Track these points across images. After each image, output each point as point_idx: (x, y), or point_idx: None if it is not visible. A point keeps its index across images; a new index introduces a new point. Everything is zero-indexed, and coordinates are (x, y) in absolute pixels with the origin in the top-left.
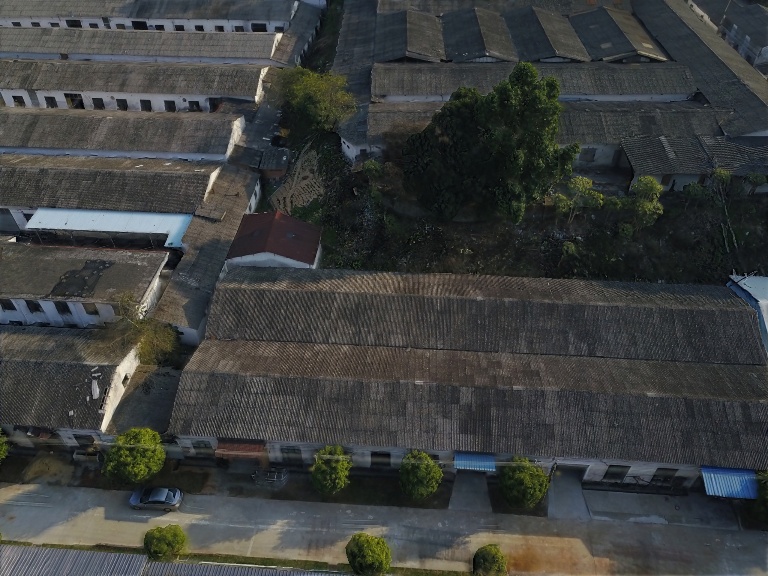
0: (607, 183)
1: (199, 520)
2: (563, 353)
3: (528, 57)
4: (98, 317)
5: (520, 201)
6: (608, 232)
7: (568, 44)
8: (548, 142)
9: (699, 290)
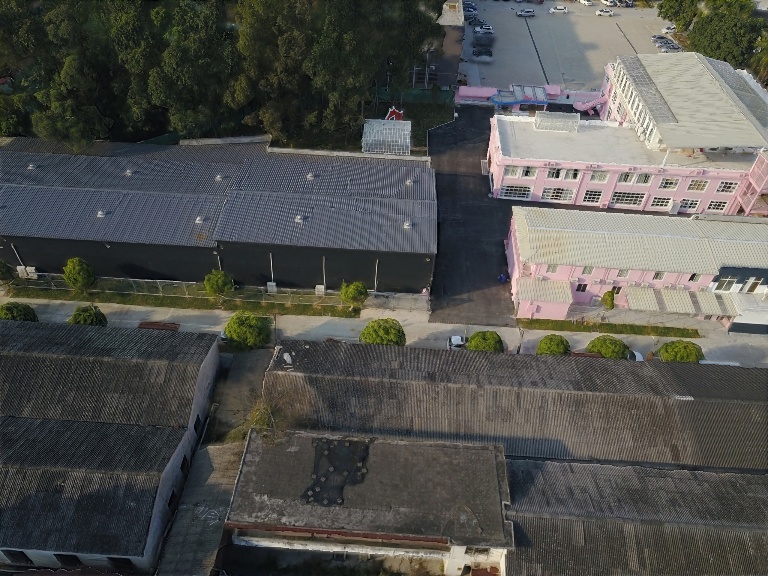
0: None
1: (208, 327)
2: None
3: None
4: None
5: None
6: None
7: None
8: None
9: None
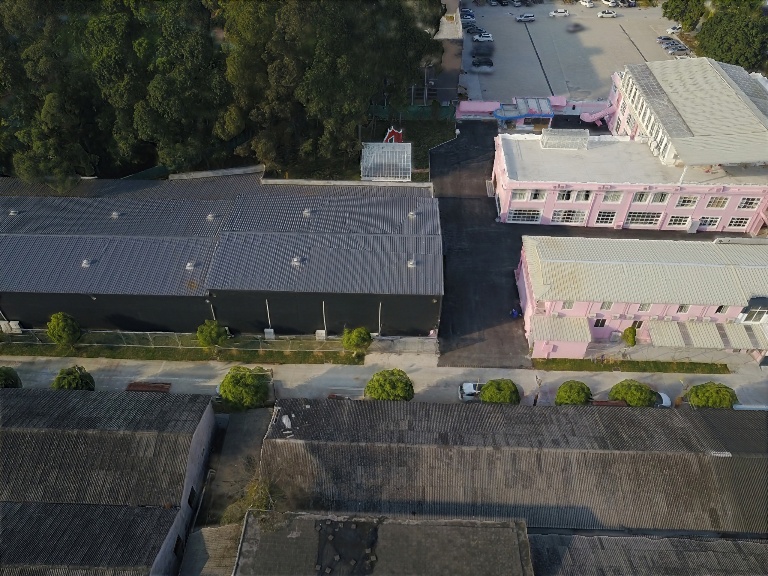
0: None
1: (203, 381)
2: None
3: None
4: None
5: None
6: None
7: None
8: None
9: None
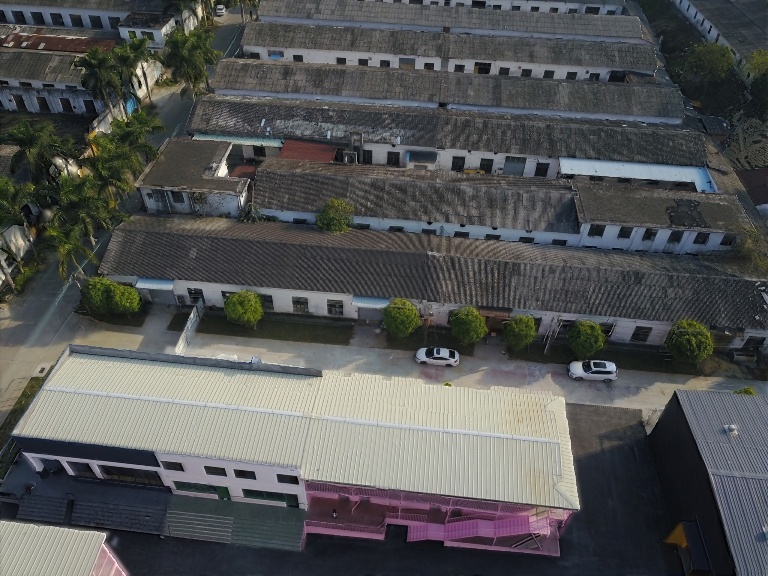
0: None
1: None
2: None
3: None
4: (703, 246)
5: None
6: None
7: None
8: None
9: None
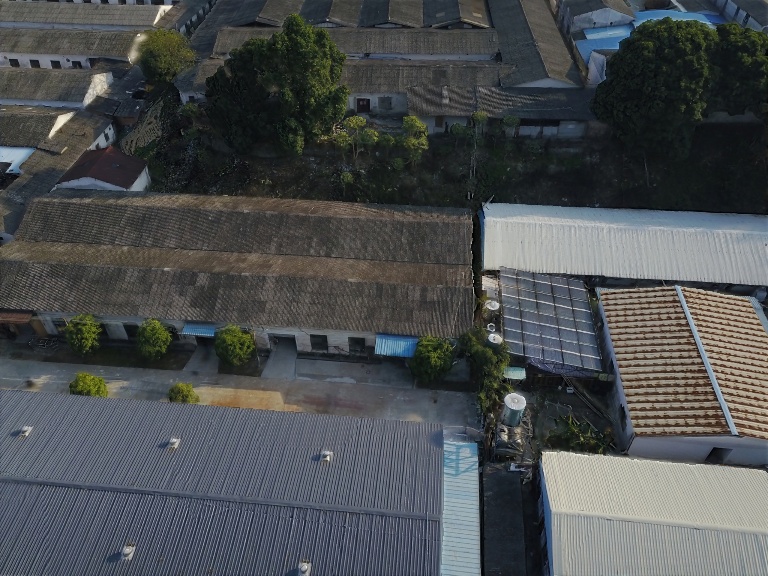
0: (398, 127)
1: None
2: (304, 254)
3: (365, 23)
4: None
5: (297, 134)
6: (389, 167)
7: (407, 13)
8: (315, 82)
9: (441, 210)
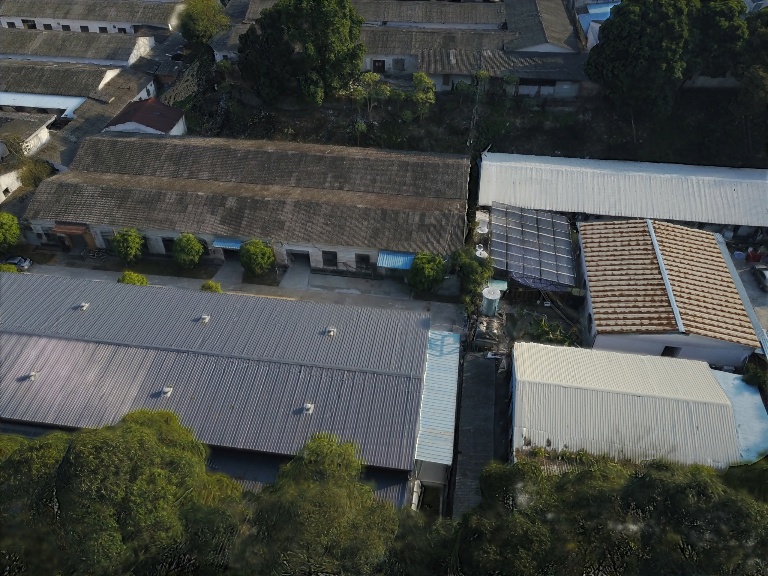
0: (409, 86)
1: None
2: (320, 187)
3: None
4: None
5: (318, 86)
6: (399, 120)
7: None
8: (335, 39)
9: (443, 155)
